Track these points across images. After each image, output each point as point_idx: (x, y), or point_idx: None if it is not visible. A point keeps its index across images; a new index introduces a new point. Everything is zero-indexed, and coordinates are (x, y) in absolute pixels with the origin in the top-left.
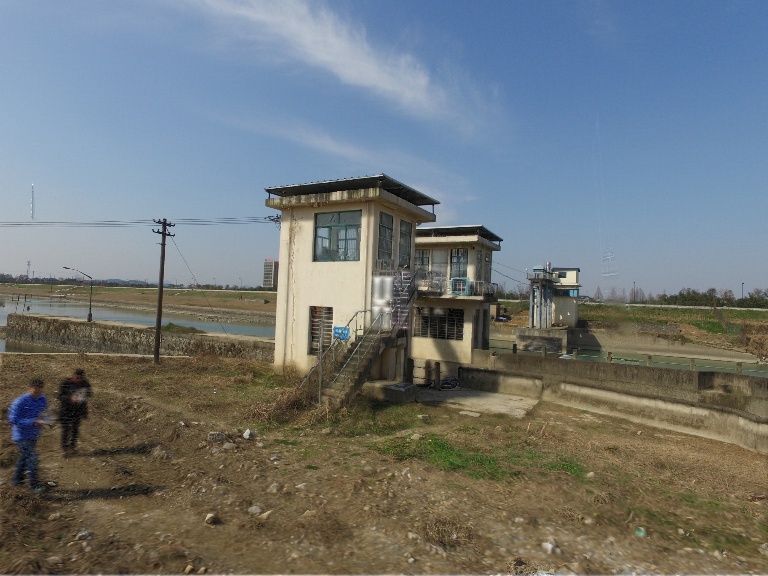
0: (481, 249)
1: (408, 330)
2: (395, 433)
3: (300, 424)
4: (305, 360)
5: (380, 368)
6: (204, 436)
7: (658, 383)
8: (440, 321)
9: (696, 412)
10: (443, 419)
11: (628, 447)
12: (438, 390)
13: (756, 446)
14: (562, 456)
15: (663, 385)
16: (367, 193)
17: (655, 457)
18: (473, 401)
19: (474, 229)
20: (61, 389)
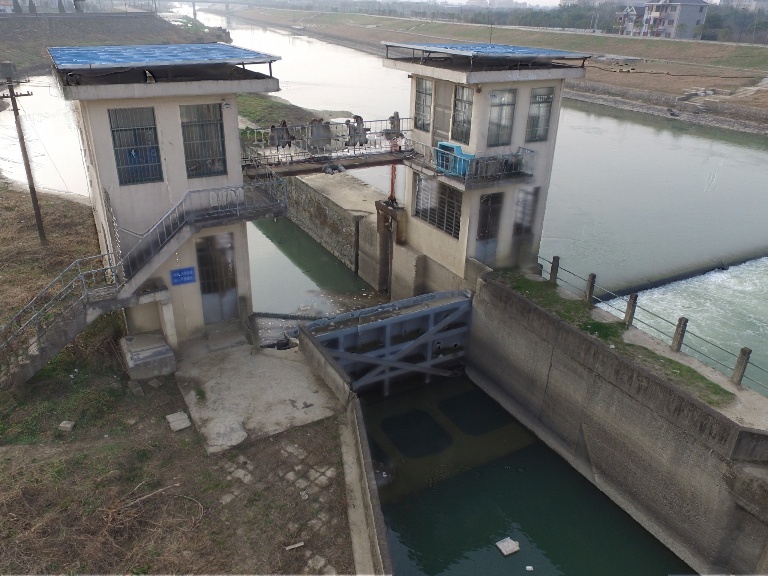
0: (513, 85)
1: (236, 260)
2: None
3: None
4: None
5: (158, 318)
6: None
7: (672, 418)
8: (440, 202)
9: None
10: (105, 429)
11: (184, 575)
12: (250, 352)
13: None
14: None
15: (679, 425)
16: None
17: None
18: (231, 394)
19: None
20: None
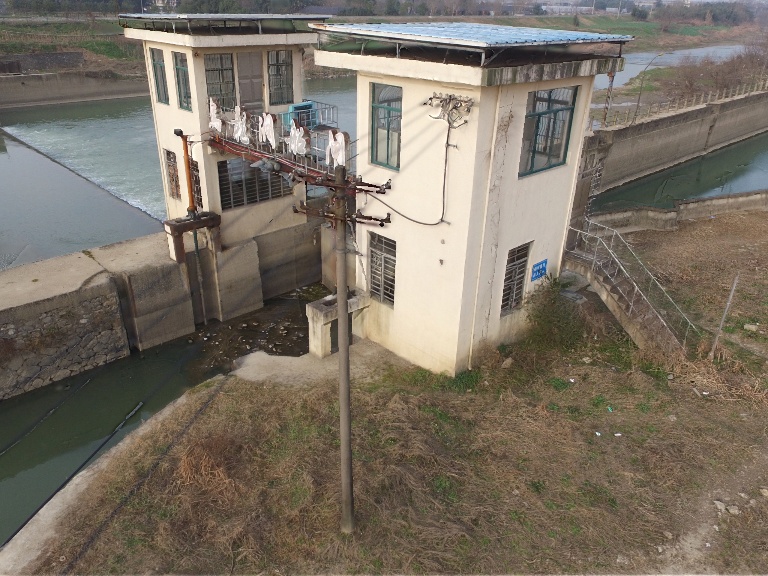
0: None
1: None
2: (720, 336)
3: (748, 378)
4: (498, 328)
5: None
6: None
7: None
8: (259, 175)
9: (626, 215)
10: None
11: (679, 261)
12: None
13: (665, 227)
14: (763, 288)
15: None
16: (615, 66)
17: (698, 261)
18: None
19: None
20: None
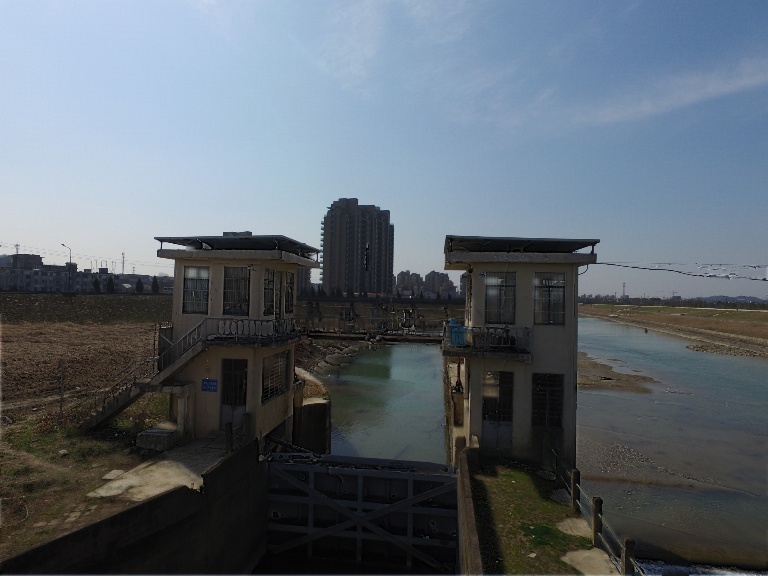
0: (510, 268)
1: (247, 382)
2: (20, 451)
3: None
4: None
5: None
6: (7, 415)
7: None
8: None
9: None
10: (76, 463)
11: None
12: None
13: None
14: None
15: None
16: None
17: None
18: (162, 470)
19: (457, 242)
20: (129, 384)
